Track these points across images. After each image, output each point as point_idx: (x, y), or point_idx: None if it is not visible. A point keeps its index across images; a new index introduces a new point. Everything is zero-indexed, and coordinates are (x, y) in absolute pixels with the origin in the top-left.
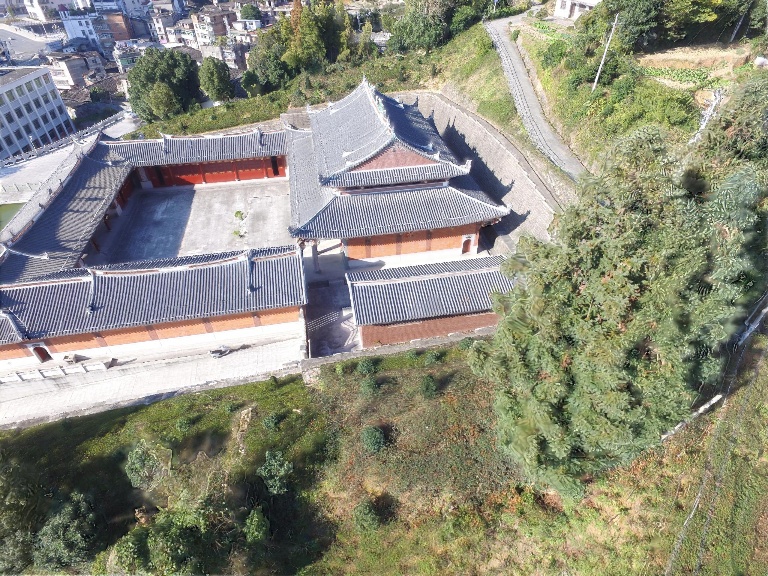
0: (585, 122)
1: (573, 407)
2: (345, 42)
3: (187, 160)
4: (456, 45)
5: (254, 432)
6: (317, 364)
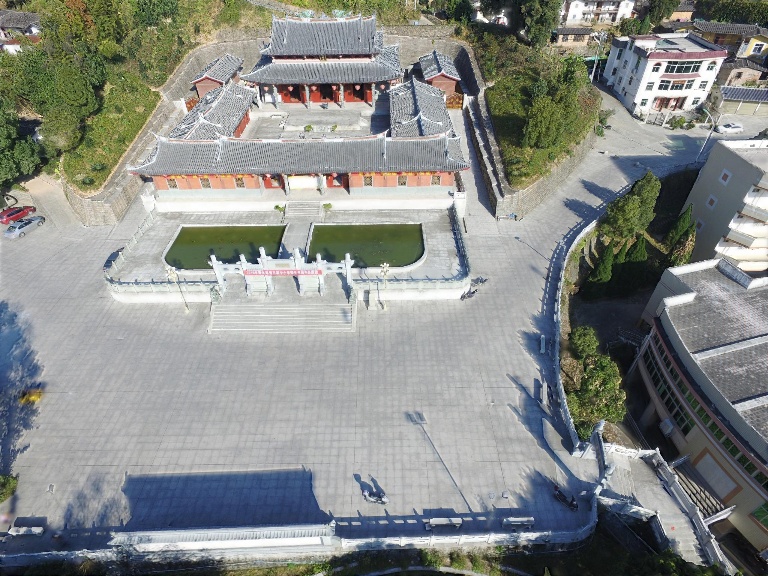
0: (354, 8)
1: (558, 2)
2: (124, 24)
3: (236, 122)
4: (187, 7)
5: (523, 81)
6: (483, 84)
